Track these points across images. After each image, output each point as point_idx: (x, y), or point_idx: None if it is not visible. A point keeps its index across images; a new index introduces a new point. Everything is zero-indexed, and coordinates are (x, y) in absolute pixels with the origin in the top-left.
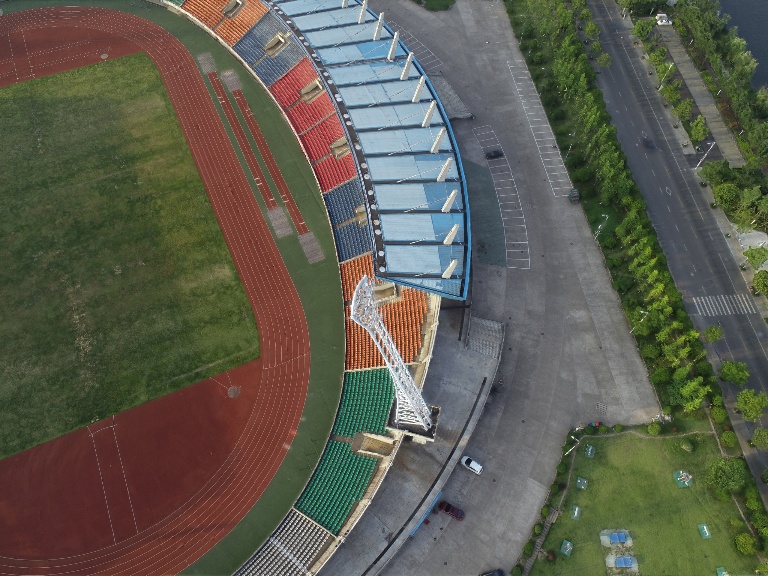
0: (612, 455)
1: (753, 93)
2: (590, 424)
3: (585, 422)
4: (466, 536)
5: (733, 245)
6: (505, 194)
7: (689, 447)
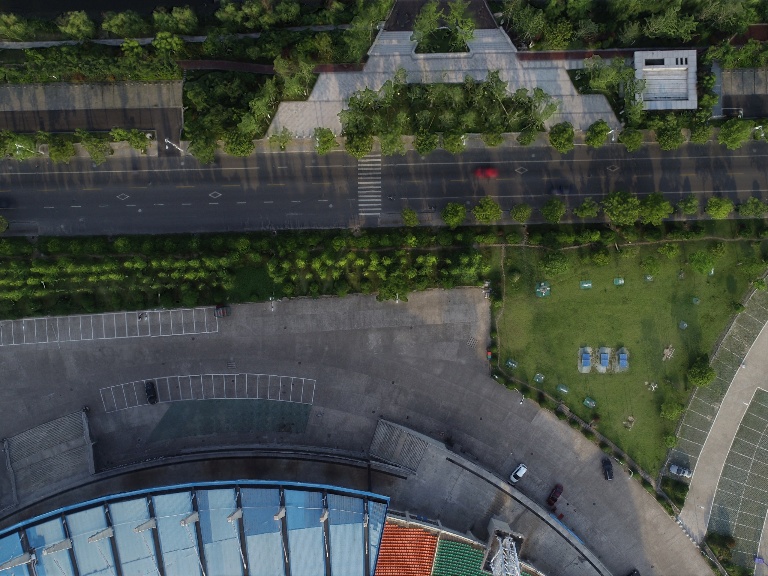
0: (517, 345)
1: (50, 23)
2: (489, 360)
3: (485, 362)
4: (575, 485)
5: (295, 147)
6: (212, 390)
7: (516, 276)
